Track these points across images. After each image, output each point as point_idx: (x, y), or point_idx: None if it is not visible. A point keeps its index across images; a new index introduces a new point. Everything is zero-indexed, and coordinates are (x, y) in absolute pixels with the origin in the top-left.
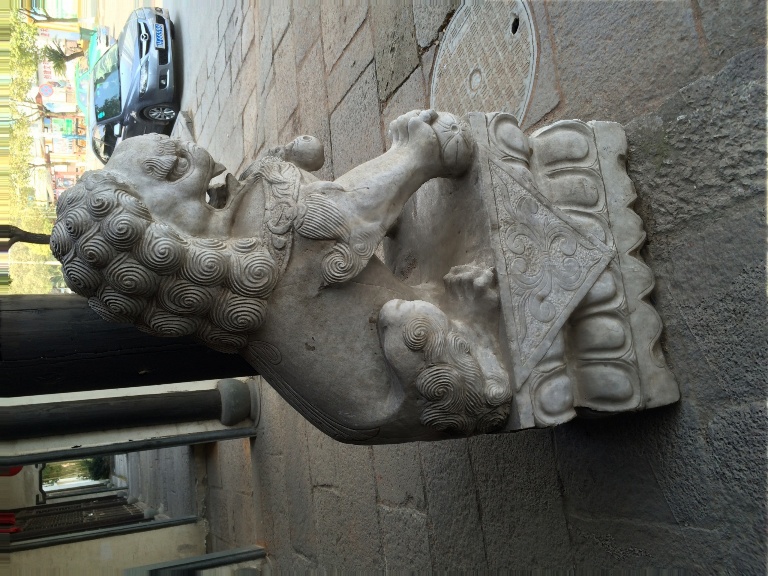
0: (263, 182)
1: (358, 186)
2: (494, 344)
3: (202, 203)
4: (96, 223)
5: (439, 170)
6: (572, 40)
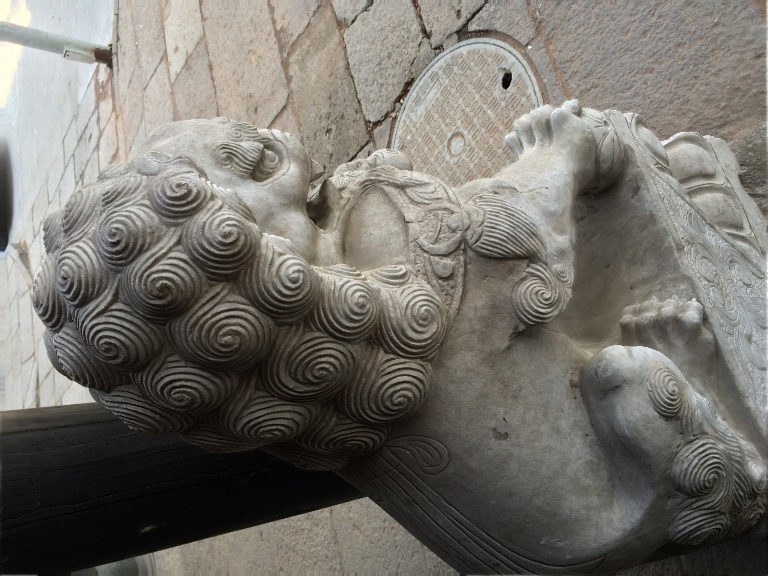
0: (385, 188)
1: (533, 185)
2: (719, 405)
3: (305, 217)
4: (172, 229)
5: (590, 179)
6: (595, 82)
